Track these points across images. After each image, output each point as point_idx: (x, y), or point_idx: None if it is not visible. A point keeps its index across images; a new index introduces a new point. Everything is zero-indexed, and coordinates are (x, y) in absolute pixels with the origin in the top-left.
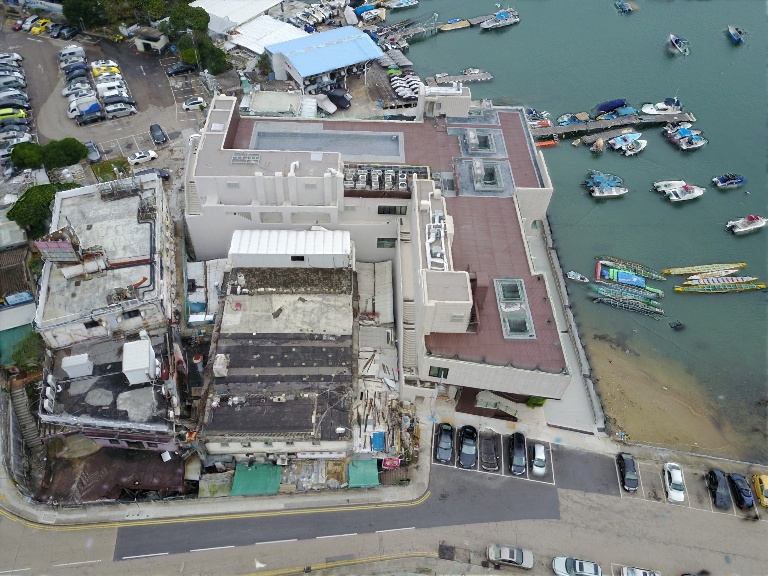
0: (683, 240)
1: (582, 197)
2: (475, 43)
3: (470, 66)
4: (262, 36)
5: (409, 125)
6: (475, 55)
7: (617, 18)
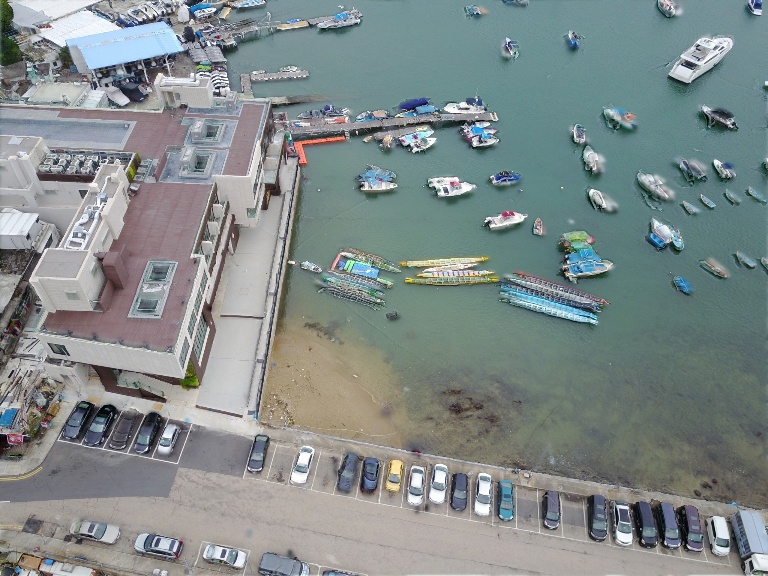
0: (435, 234)
1: (352, 191)
2: (310, 43)
3: (291, 64)
4: (72, 30)
5: (146, 114)
6: (304, 54)
7: (465, 21)
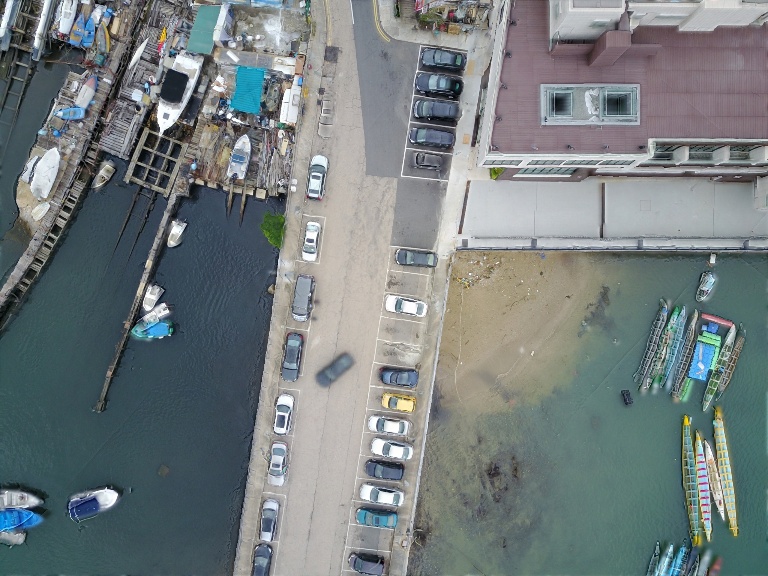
0: None
1: None
2: None
3: None
4: None
5: None
6: None
7: None
